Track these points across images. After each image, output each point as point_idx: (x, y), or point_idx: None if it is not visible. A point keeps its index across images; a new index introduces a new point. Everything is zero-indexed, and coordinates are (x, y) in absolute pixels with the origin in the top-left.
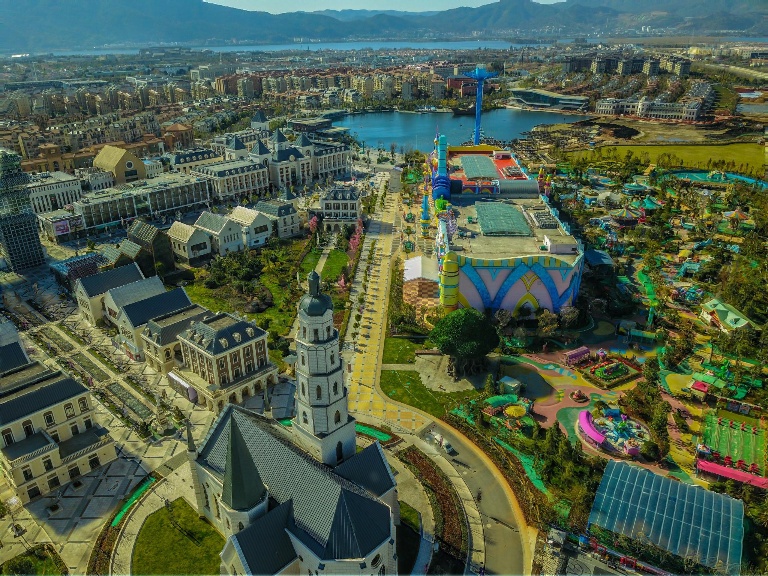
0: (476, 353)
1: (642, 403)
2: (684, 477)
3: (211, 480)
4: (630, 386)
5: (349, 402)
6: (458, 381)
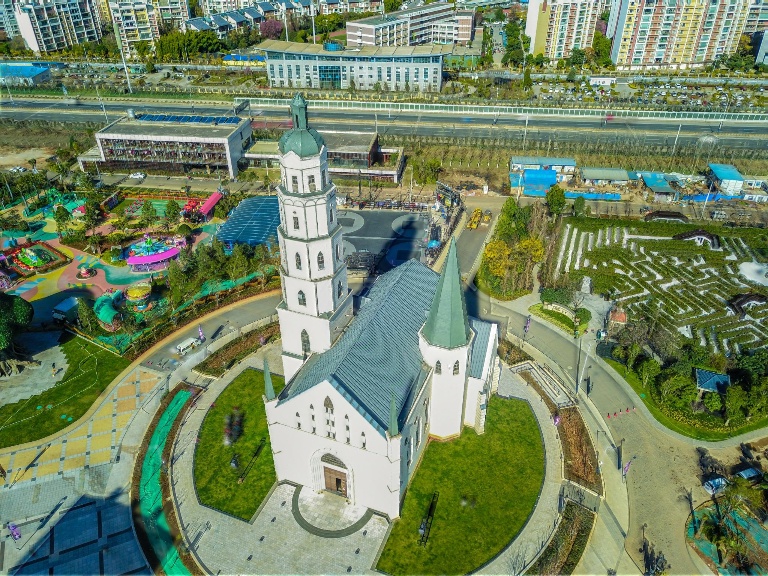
0: (31, 306)
1: (103, 240)
2: (209, 227)
3: (411, 418)
4: (66, 249)
5: (90, 462)
6: (38, 361)
